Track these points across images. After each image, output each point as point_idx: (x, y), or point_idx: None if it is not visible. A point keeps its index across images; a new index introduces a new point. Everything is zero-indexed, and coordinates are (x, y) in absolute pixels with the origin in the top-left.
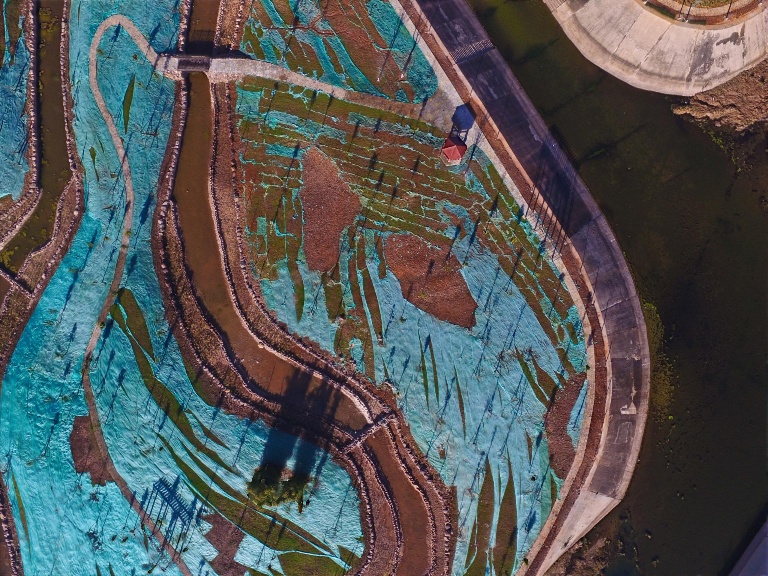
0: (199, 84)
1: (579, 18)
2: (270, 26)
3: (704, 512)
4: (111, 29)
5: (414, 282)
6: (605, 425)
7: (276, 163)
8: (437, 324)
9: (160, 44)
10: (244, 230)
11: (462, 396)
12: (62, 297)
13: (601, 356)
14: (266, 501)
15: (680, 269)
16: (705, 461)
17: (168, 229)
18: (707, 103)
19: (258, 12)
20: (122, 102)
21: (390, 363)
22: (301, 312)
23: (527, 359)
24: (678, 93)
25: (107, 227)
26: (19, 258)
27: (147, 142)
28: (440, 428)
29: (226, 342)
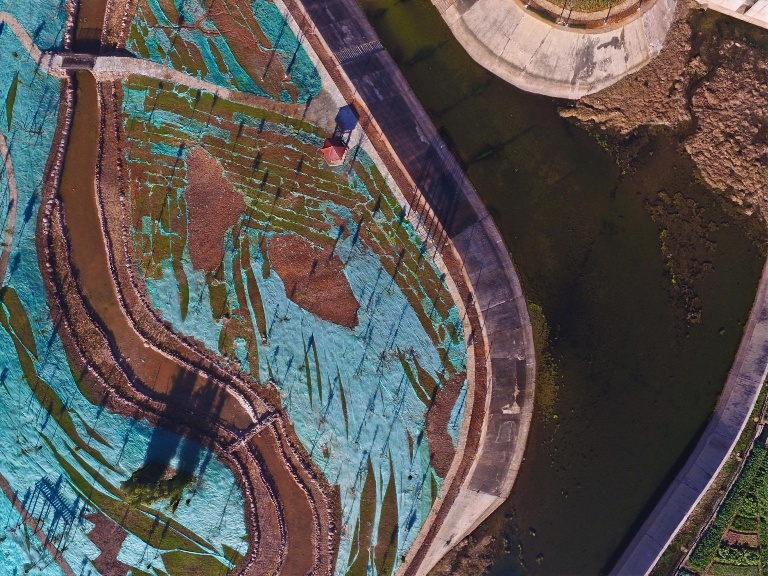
0: (86, 82)
1: (466, 21)
2: (155, 25)
3: (588, 510)
4: None
5: (298, 282)
6: (485, 424)
7: (161, 162)
8: (320, 324)
9: (45, 42)
10: (129, 229)
11: (345, 395)
12: None
13: (481, 356)
14: (143, 500)
15: (565, 270)
16: (589, 460)
17: (54, 227)
18: (593, 106)
19: (144, 11)
20: (5, 99)
21: (274, 362)
22: (186, 311)
23: (409, 359)
24: (564, 96)
25: None
26: None
27: (31, 140)
28: (323, 427)
29: (111, 341)
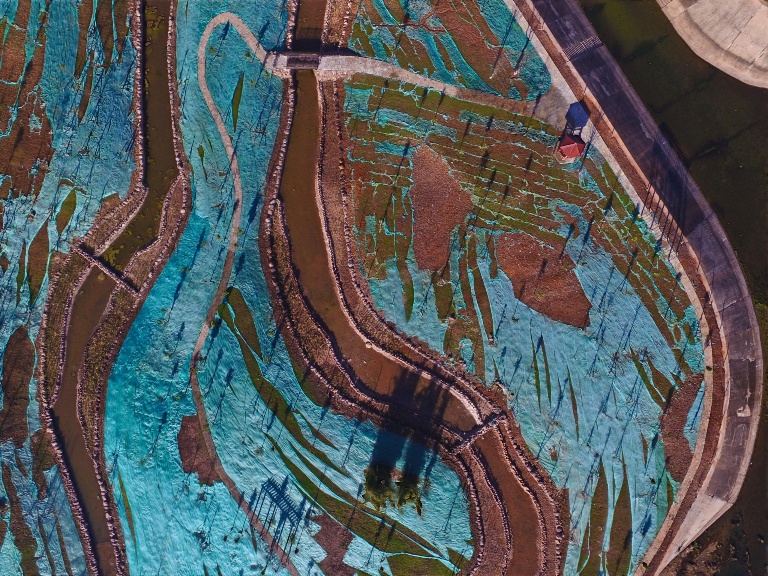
0: (306, 82)
1: (691, 14)
2: (380, 23)
3: None
4: (220, 27)
5: (526, 281)
6: (723, 427)
7: (386, 161)
8: (550, 324)
9: (269, 42)
10: (352, 229)
11: (575, 397)
12: (170, 296)
13: (719, 357)
14: None
15: None
16: None
17: (275, 228)
18: None
19: (367, 9)
20: (231, 100)
21: (501, 363)
22: (410, 312)
23: (642, 360)
24: None
25: (215, 226)
26: (124, 257)
27: (256, 140)
28: (552, 429)
29: (333, 342)
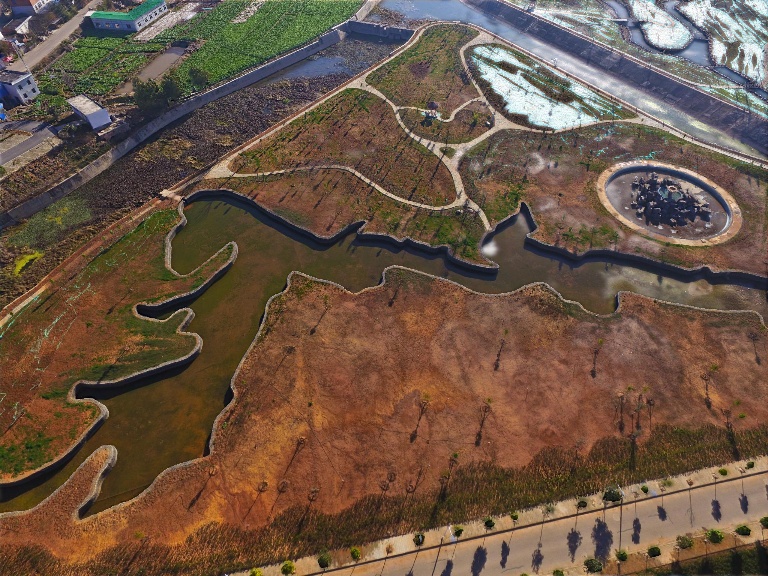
0: None
1: None
2: None
3: None
4: None
5: None
6: None
7: None
8: None
9: None
10: None
11: None
12: None
13: None
14: None
15: None
16: None
17: None
18: None
19: None
20: None
21: None
22: None
23: None
24: None
25: (644, 0)
26: None
27: None
28: None
29: None
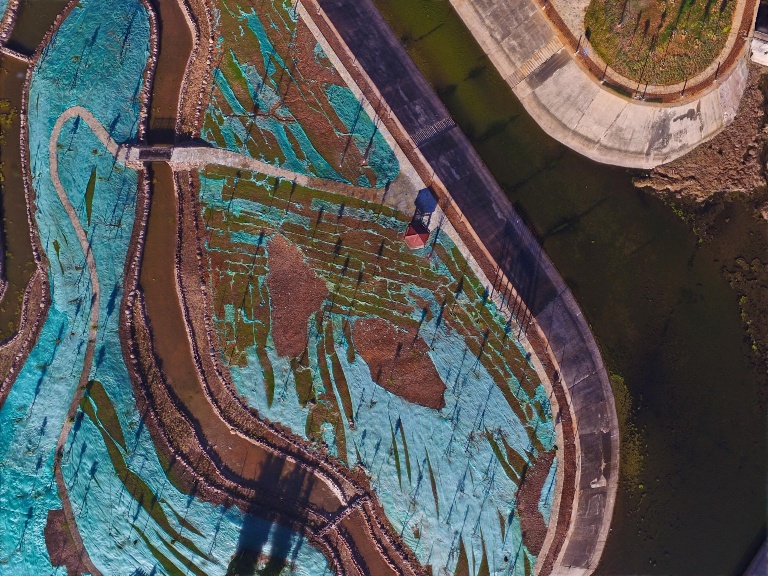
0: (162, 172)
1: (538, 95)
2: (230, 114)
3: None
4: (70, 121)
5: (383, 365)
6: (575, 501)
7: (241, 251)
8: (407, 406)
9: (121, 134)
10: (212, 318)
11: (434, 477)
12: (31, 391)
13: (569, 433)
14: None
15: (646, 340)
16: (676, 528)
17: (136, 318)
18: (667, 175)
19: (218, 100)
20: (84, 194)
21: (362, 446)
22: (272, 398)
23: (497, 438)
24: (638, 166)
25: (74, 320)
26: None
27: (111, 233)
28: (413, 509)
29: (198, 429)
